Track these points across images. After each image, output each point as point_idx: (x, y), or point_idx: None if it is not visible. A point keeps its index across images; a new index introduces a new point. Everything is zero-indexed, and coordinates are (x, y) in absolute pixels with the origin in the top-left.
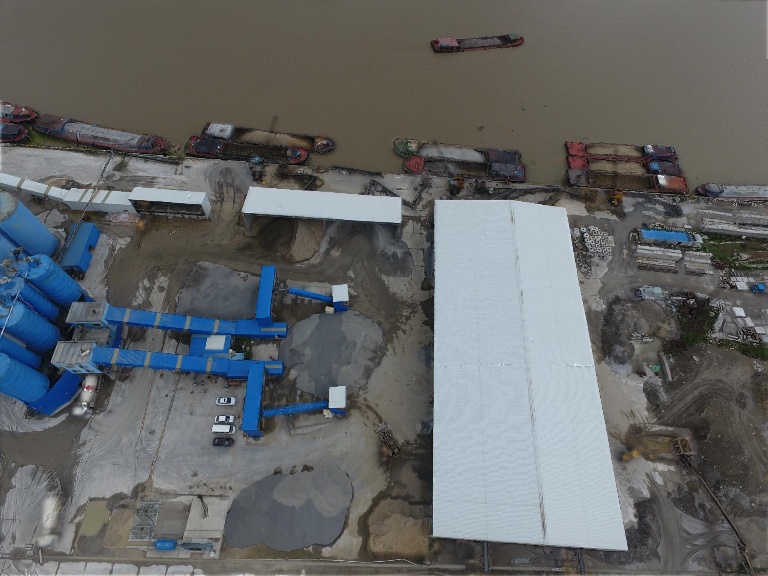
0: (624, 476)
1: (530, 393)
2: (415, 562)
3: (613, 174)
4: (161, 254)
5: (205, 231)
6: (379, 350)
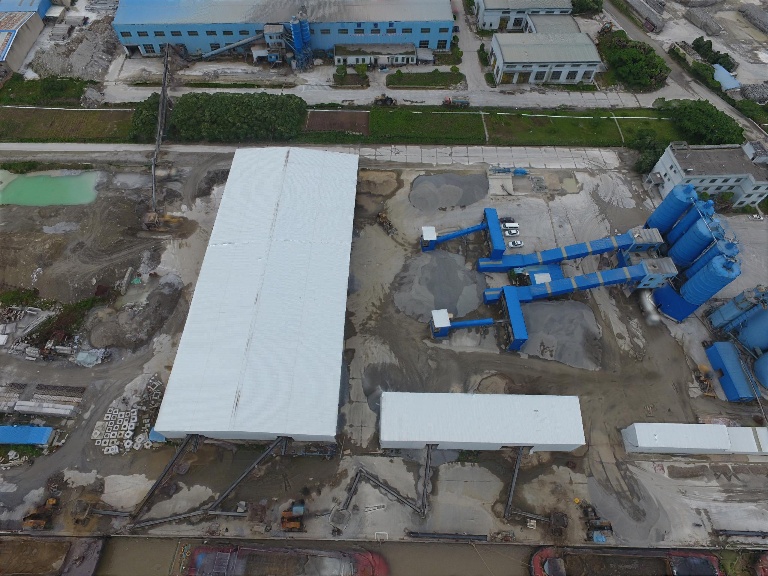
0: (210, 209)
1: (275, 220)
2: (367, 169)
3: (14, 574)
4: (645, 377)
5: (615, 412)
6: (397, 287)
